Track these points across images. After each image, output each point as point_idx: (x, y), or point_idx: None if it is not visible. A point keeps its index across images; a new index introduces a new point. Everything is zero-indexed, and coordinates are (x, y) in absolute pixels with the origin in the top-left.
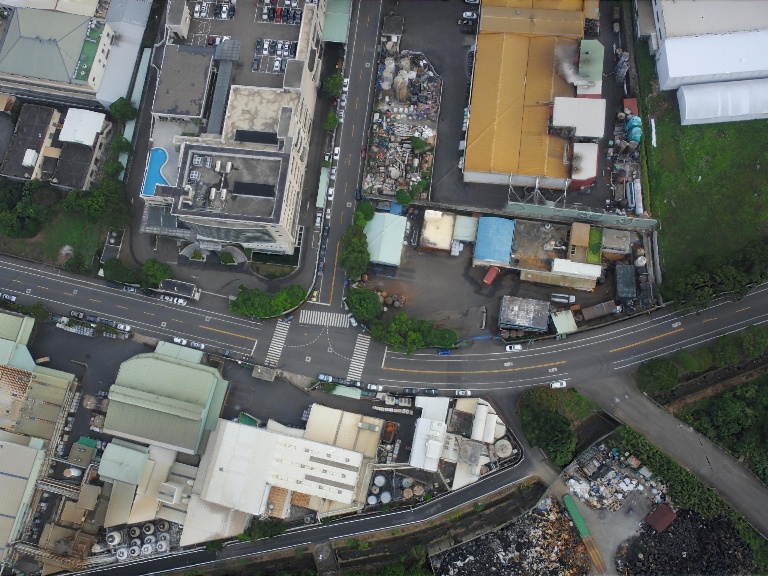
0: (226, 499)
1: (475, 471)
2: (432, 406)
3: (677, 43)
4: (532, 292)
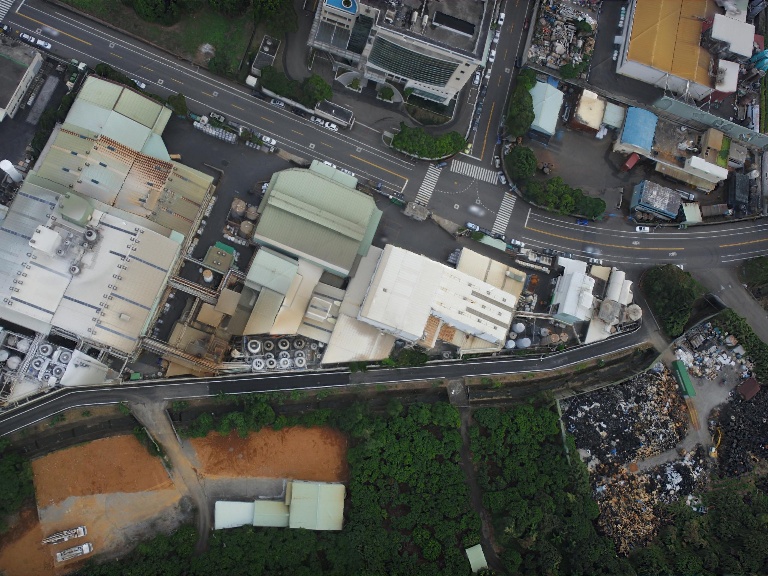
0: (389, 318)
1: (607, 329)
2: (573, 267)
3: None
4: (660, 184)
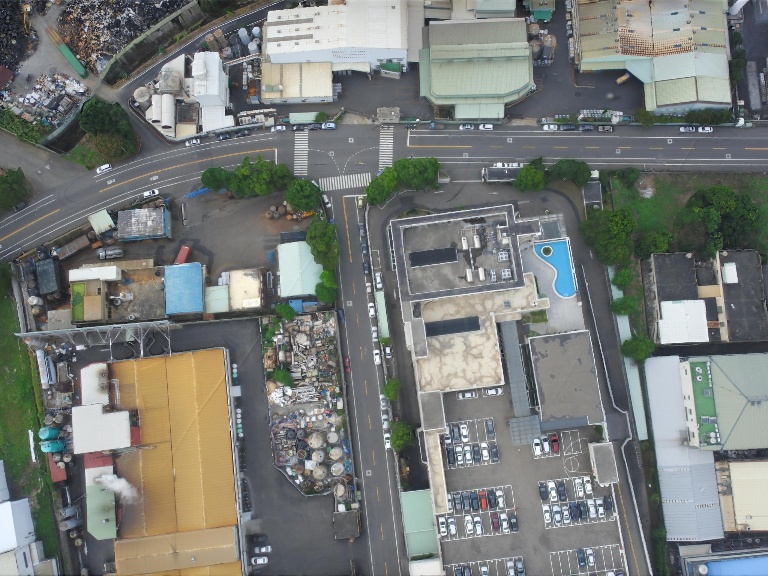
0: None
1: None
2: (217, 120)
3: (3, 546)
4: (142, 253)
